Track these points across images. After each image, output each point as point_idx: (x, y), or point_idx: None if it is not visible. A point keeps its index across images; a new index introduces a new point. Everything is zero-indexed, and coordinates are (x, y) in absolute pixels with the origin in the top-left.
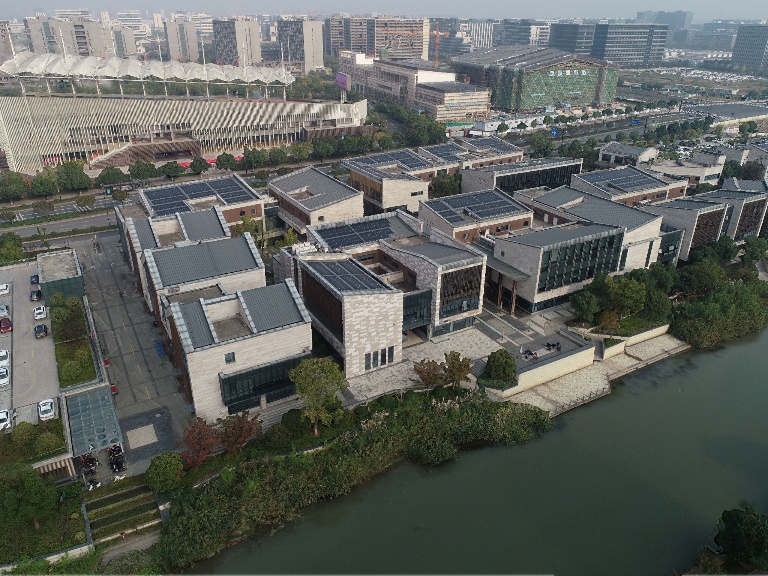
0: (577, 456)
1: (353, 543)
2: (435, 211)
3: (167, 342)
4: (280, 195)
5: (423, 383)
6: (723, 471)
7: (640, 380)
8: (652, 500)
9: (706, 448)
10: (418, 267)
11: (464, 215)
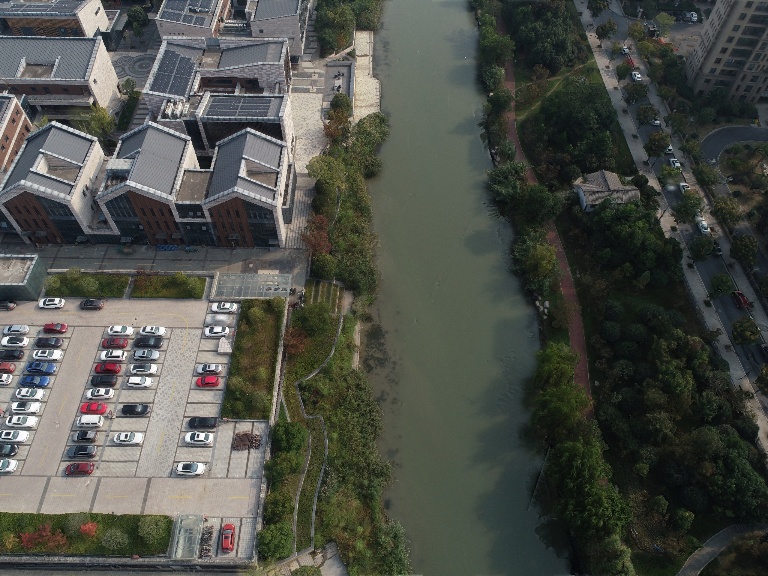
0: (414, 121)
1: (405, 221)
2: (181, 22)
3: (185, 234)
4: (8, 83)
5: (331, 139)
6: (454, 87)
7: (381, 67)
8: (452, 117)
9: (439, 81)
10: (259, 73)
11: (193, 14)
